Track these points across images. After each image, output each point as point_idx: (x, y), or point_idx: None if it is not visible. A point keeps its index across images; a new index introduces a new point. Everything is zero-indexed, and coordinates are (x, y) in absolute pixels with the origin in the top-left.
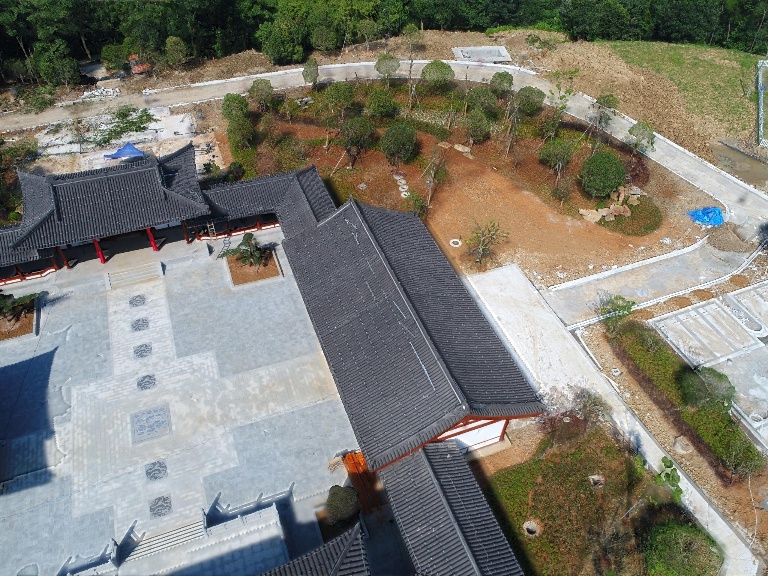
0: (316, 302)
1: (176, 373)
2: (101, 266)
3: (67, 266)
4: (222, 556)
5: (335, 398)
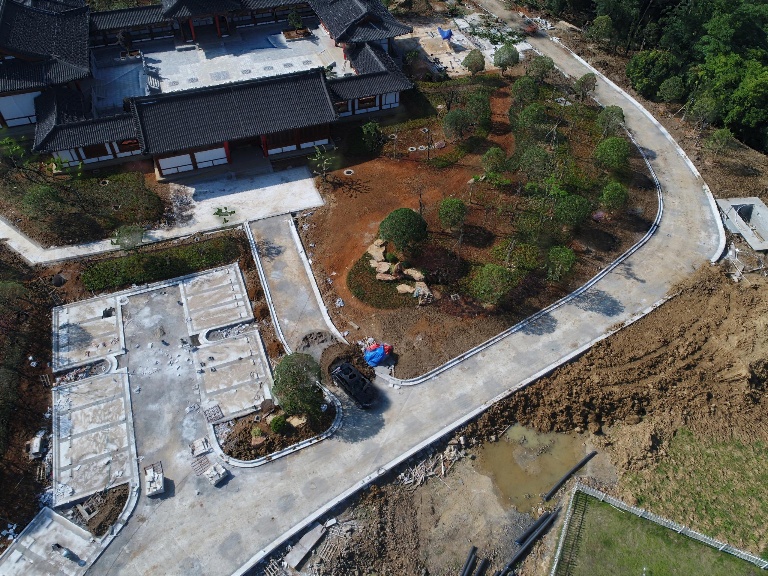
0: None
1: None
2: (333, 46)
3: (331, 36)
4: (139, 95)
5: None
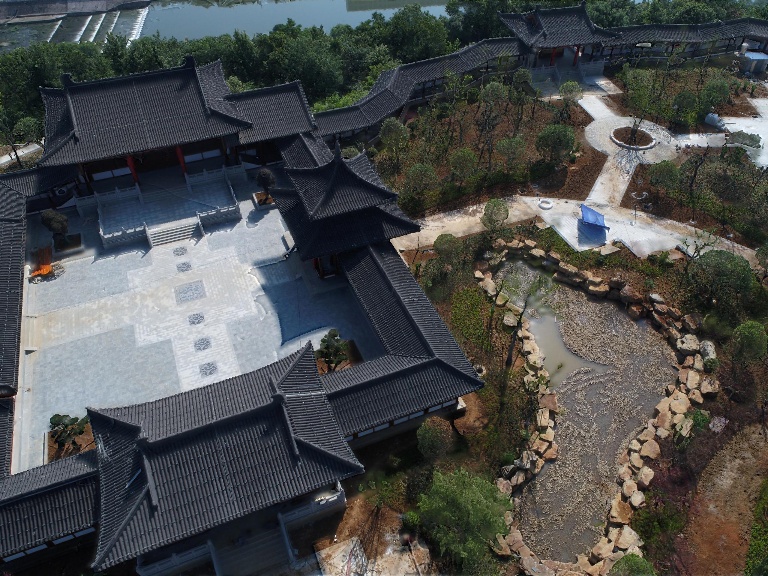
0: (8, 318)
1: (172, 327)
2: None
3: None
4: None
5: (41, 313)
